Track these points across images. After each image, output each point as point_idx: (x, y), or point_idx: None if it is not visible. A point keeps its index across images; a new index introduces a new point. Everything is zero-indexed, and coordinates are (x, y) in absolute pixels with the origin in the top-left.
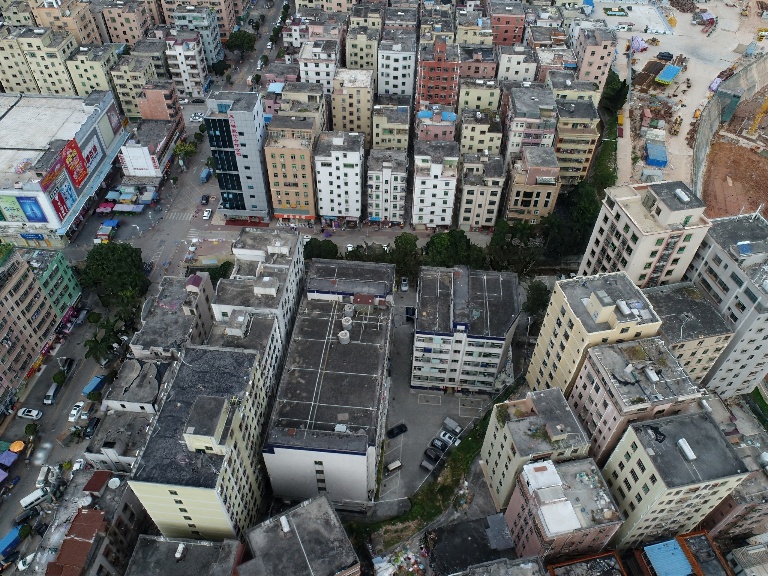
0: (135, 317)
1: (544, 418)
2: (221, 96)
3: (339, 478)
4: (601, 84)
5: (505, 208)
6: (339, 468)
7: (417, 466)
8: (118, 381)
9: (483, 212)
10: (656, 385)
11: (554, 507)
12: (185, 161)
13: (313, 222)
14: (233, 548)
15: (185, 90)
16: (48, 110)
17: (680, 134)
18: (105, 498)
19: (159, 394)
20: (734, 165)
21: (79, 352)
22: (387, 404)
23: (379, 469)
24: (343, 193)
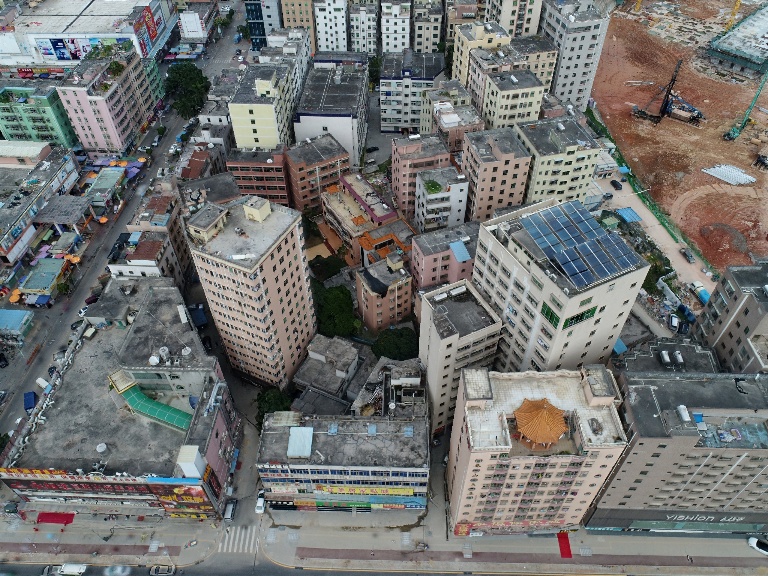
0: (201, 108)
1: None
2: None
3: None
4: None
5: (445, 43)
6: (337, 132)
7: None
8: (204, 109)
9: (430, 44)
10: (503, 60)
11: (448, 116)
12: (222, 31)
13: None
14: (282, 147)
15: None
16: None
17: None
18: None
19: None
20: (620, 29)
21: (168, 125)
22: (366, 134)
23: (362, 163)
24: (334, 33)
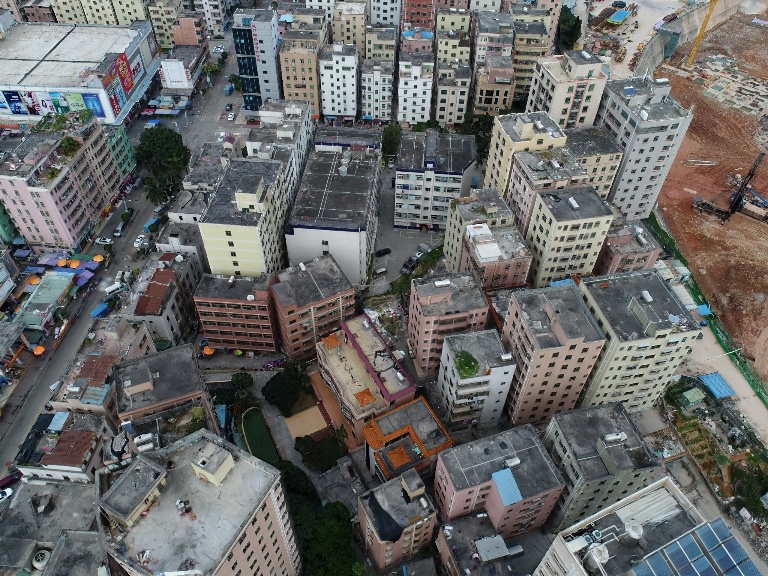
0: (179, 184)
1: (483, 203)
2: (245, 12)
3: (340, 259)
4: (555, 15)
5: (473, 109)
6: (340, 247)
7: (398, 273)
8: (176, 202)
9: (455, 110)
10: (558, 171)
11: (485, 246)
12: (211, 79)
13: (318, 122)
14: (268, 277)
15: (208, 28)
16: (99, 35)
17: (624, 61)
18: (173, 268)
19: None
20: None
21: (137, 206)
22: (376, 233)
23: (369, 273)
24: (342, 94)
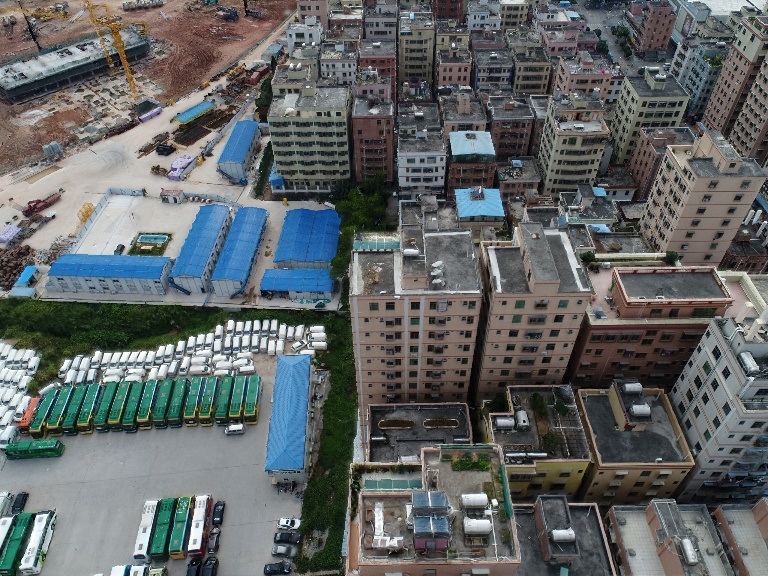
0: None
1: None
2: None
3: None
4: None
5: None
6: None
7: None
8: None
9: None
10: None
11: None
12: None
13: None
14: None
15: None
16: None
17: None
18: None
19: None
20: None
21: None
22: None
23: None
24: None
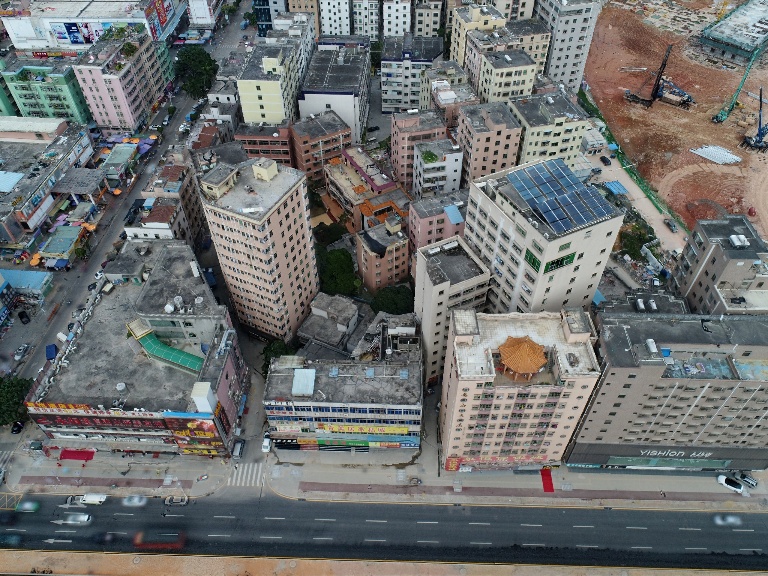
0: None
1: None
2: None
3: None
4: None
5: (445, 30)
6: (339, 110)
7: None
8: (213, 88)
9: (430, 30)
10: (498, 40)
11: (445, 93)
12: (229, 17)
13: None
14: (288, 121)
15: None
16: None
17: None
18: None
19: (237, 92)
20: (616, 18)
21: (178, 105)
22: (367, 114)
23: (363, 142)
24: (338, 19)
